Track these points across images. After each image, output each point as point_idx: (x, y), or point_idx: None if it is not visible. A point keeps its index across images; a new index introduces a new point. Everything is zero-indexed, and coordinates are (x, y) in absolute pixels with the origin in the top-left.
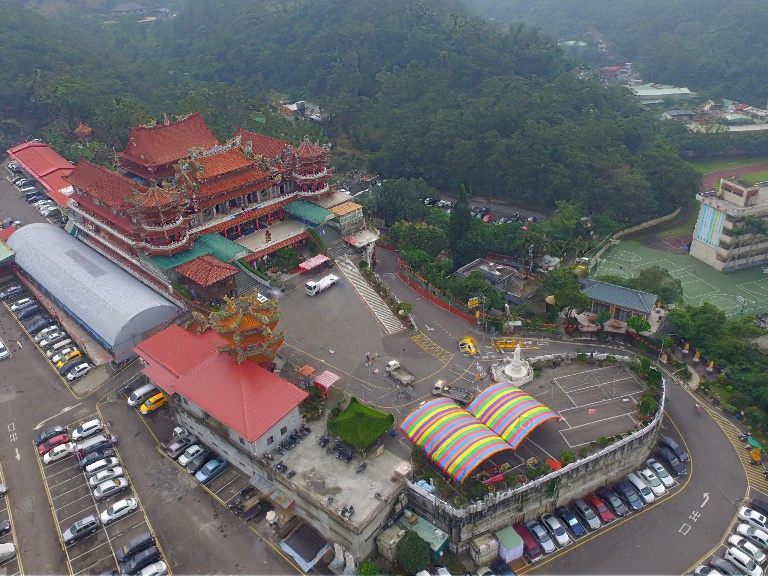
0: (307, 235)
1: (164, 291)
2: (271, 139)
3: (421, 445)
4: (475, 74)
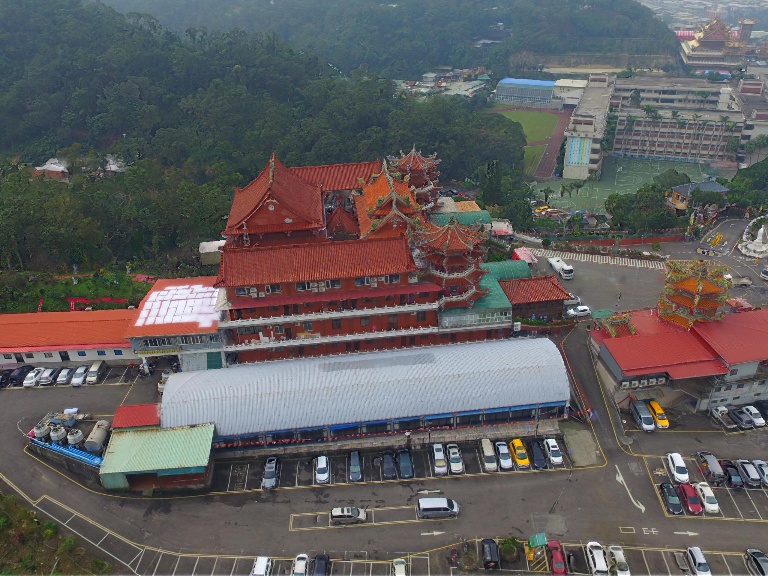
0: None
1: (486, 340)
2: (350, 165)
3: None
4: (275, 84)
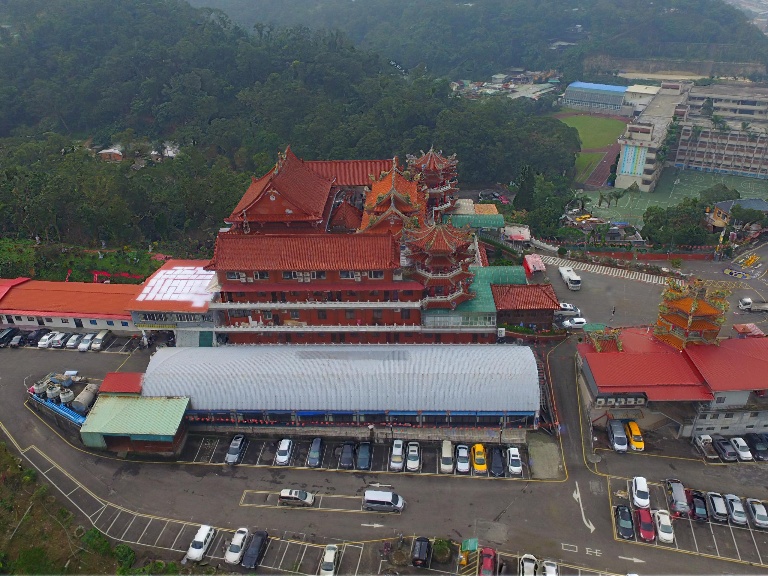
0: (483, 245)
1: (470, 343)
2: (368, 161)
3: None
4: (331, 80)
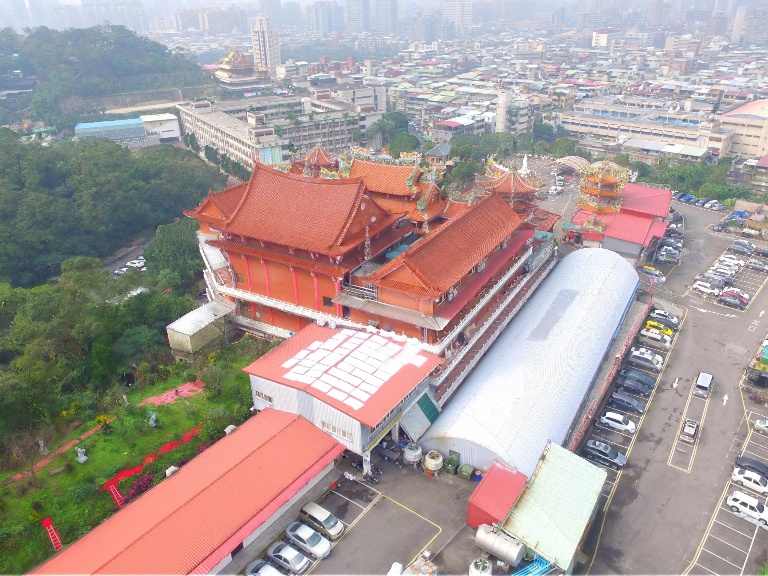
0: None
1: None
2: None
3: None
4: None
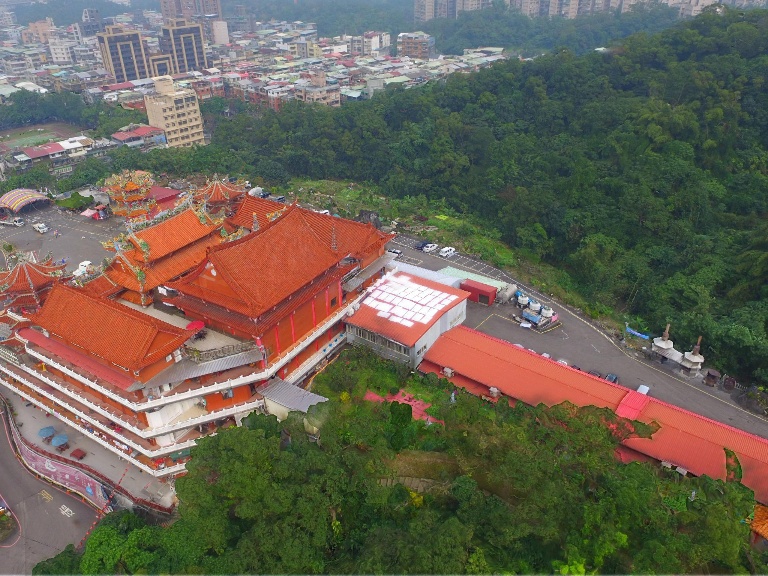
0: None
1: None
2: None
3: (47, 196)
4: None
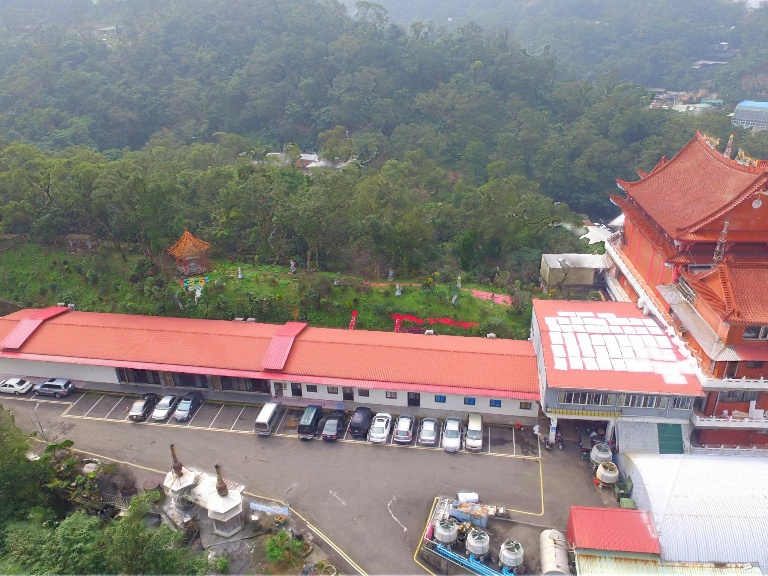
0: None
1: None
2: (763, 162)
3: None
4: None
